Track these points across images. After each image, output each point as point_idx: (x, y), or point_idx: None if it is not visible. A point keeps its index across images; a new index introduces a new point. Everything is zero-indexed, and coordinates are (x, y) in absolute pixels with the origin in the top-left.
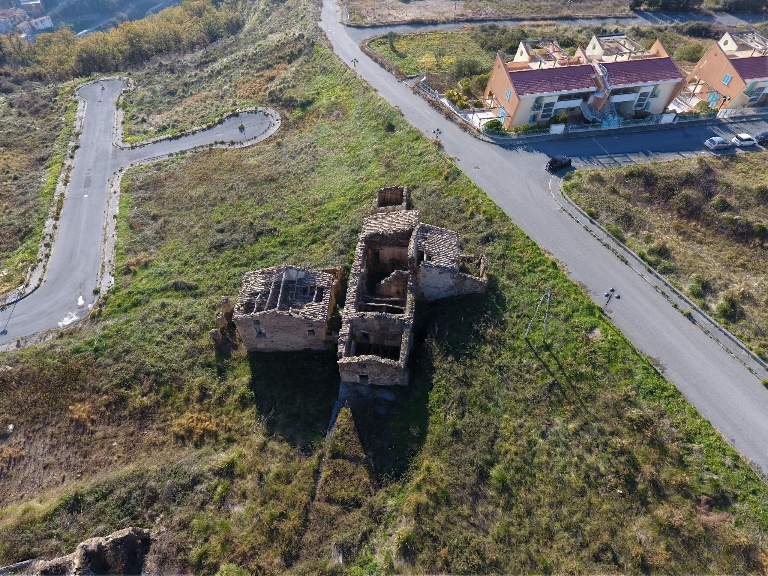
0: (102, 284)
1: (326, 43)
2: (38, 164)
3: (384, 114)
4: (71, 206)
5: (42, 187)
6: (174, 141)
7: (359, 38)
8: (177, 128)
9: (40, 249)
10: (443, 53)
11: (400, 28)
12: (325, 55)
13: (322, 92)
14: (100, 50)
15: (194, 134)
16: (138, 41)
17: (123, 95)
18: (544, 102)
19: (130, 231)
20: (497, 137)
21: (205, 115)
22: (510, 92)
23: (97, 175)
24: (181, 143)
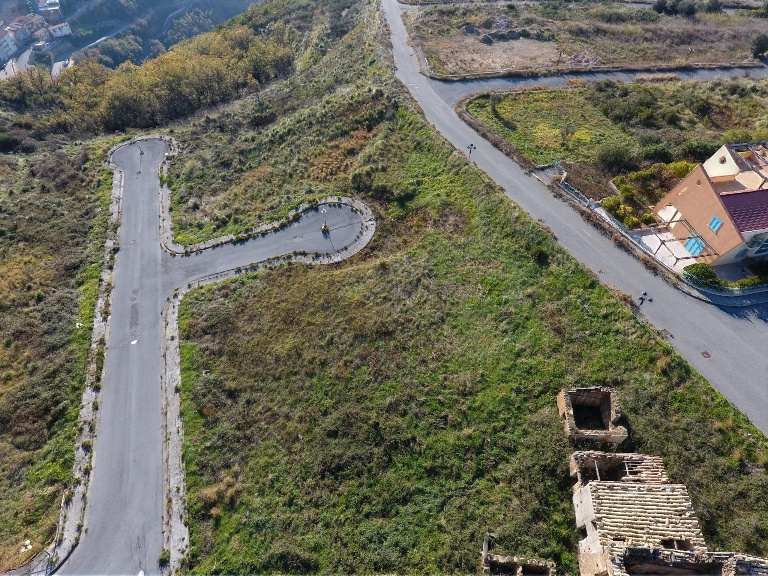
0: (171, 543)
1: (413, 105)
2: (68, 275)
3: (527, 233)
4: (115, 363)
5: (75, 323)
6: (240, 246)
7: (451, 98)
8: (241, 224)
9: (77, 455)
10: (573, 131)
11: (495, 83)
12: (416, 123)
13: (424, 181)
14: (134, 94)
15: (264, 236)
16: (178, 84)
17: (166, 163)
18: (767, 237)
19: (201, 423)
20: (711, 292)
21: (275, 206)
22: (722, 223)
23: (146, 303)
24: (249, 250)
